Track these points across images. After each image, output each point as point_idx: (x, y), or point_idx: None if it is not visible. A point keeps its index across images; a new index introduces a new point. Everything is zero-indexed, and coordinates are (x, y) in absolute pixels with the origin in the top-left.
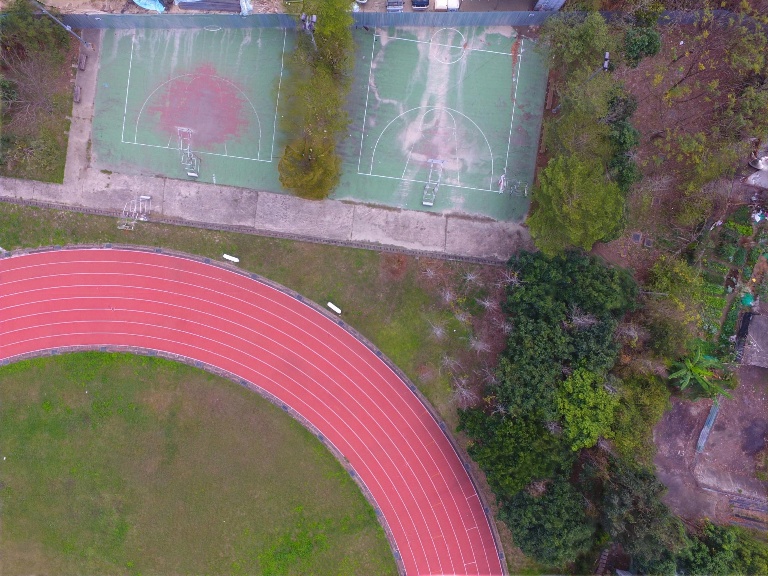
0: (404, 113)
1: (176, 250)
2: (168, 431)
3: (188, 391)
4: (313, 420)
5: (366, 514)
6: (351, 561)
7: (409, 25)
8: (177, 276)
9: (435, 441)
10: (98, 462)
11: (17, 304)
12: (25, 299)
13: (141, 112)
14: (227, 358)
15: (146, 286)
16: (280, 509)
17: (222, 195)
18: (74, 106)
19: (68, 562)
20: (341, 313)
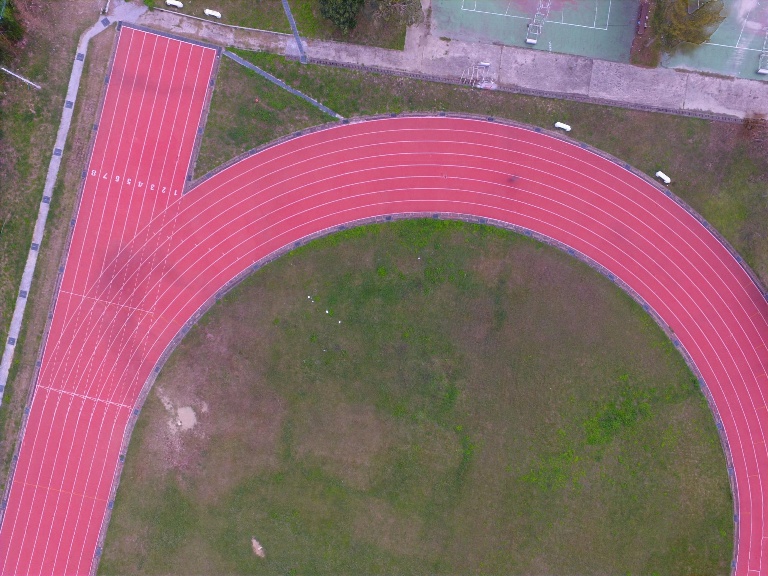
0: None
1: (508, 119)
2: (497, 298)
3: (517, 259)
4: (639, 290)
5: (691, 384)
6: (674, 430)
7: None
8: (509, 144)
9: (760, 312)
10: (429, 327)
11: (354, 171)
12: (362, 166)
13: None
14: (555, 227)
15: (478, 154)
16: (605, 377)
17: (557, 63)
18: None
19: (399, 425)
20: (669, 183)
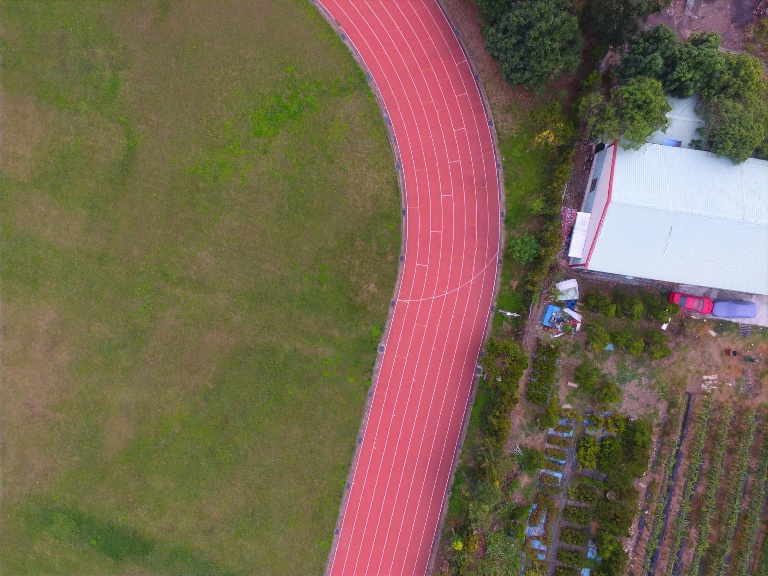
0: None
1: None
2: None
3: None
4: None
5: (357, 76)
6: (341, 124)
7: None
8: None
9: (426, 6)
10: (91, 17)
11: None
12: None
13: None
14: None
15: None
16: (271, 69)
17: None
18: None
19: (61, 116)
20: None
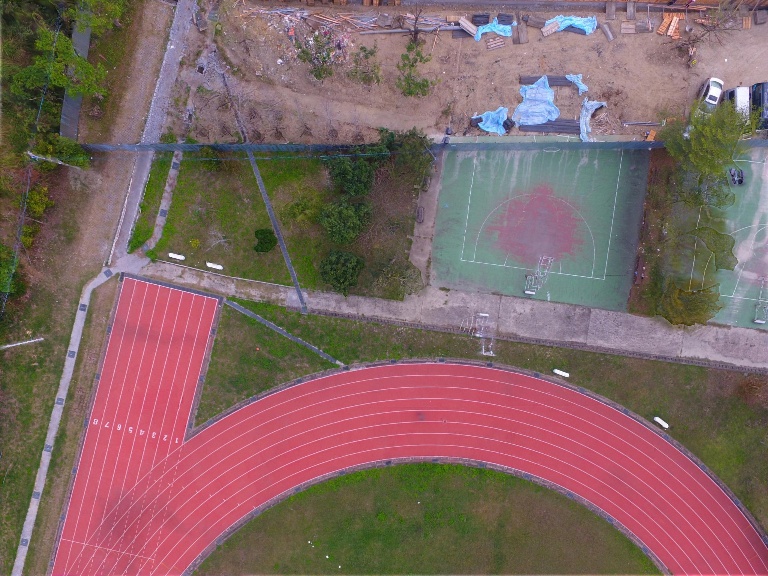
0: (736, 232)
1: (507, 364)
2: (497, 542)
3: (516, 503)
4: (638, 533)
5: None
6: None
7: (749, 148)
8: (508, 390)
9: (758, 555)
10: (429, 571)
11: (354, 416)
12: (362, 412)
13: (480, 231)
14: (554, 470)
15: (478, 400)
16: None
17: (556, 312)
18: (415, 226)
19: None
20: (667, 427)
